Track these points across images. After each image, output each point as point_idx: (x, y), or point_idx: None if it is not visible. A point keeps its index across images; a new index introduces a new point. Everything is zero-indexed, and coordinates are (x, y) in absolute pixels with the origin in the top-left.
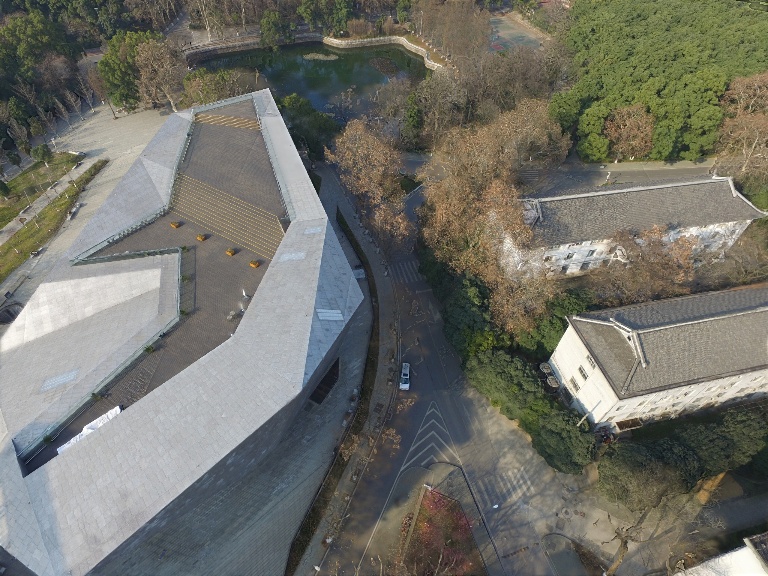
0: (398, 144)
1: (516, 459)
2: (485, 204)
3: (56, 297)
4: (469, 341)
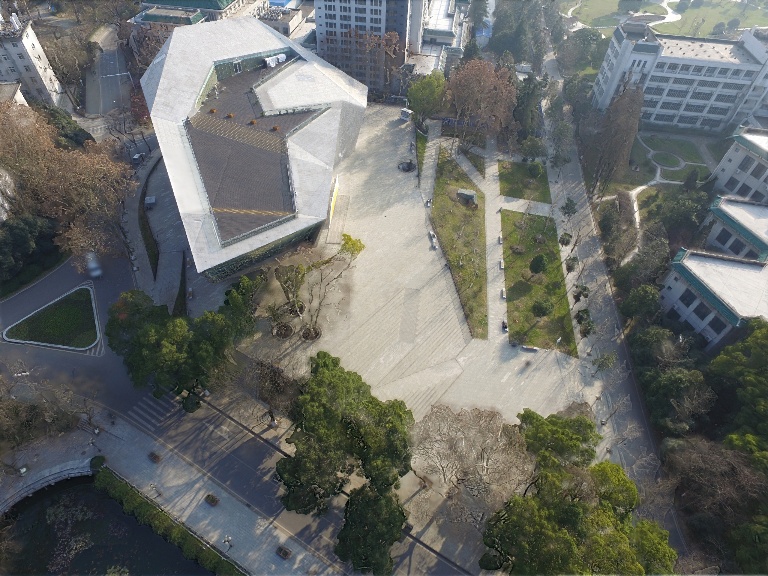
0: (5, 429)
1: None
2: (7, 118)
3: None
4: None
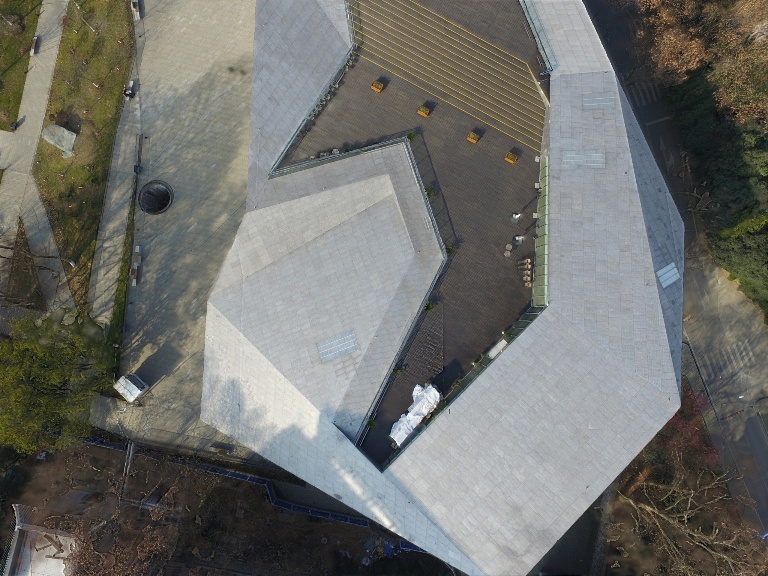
0: None
1: (742, 332)
2: None
3: (267, 226)
4: (741, 225)
